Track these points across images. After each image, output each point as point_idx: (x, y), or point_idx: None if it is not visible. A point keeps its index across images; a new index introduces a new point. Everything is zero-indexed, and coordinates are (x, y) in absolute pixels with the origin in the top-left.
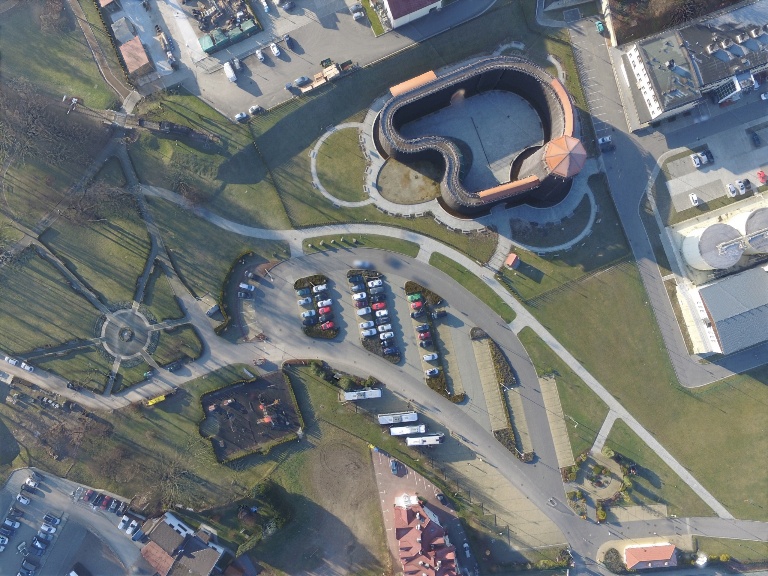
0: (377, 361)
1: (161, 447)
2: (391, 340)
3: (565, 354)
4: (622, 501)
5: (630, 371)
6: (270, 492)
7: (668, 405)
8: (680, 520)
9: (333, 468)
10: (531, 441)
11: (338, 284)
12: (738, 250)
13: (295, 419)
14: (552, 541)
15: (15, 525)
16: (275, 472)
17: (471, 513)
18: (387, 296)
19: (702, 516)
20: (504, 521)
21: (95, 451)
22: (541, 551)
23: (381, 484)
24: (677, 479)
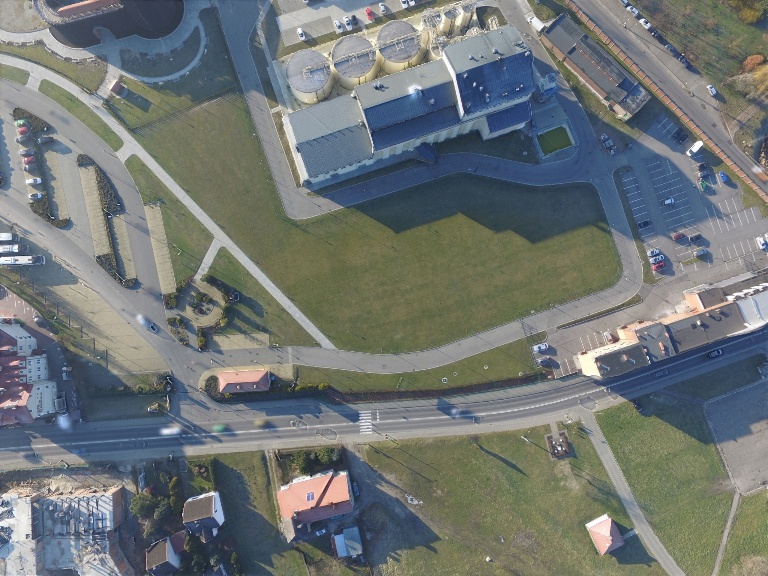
0: None
1: None
2: None
3: (171, 182)
4: (224, 329)
5: (236, 201)
6: None
7: (273, 235)
8: (282, 349)
9: None
10: (135, 268)
11: None
12: (324, 75)
13: None
14: (153, 367)
15: None
16: None
17: (69, 336)
18: None
19: (304, 346)
20: (103, 345)
21: None
22: (140, 376)
23: None
24: (279, 308)
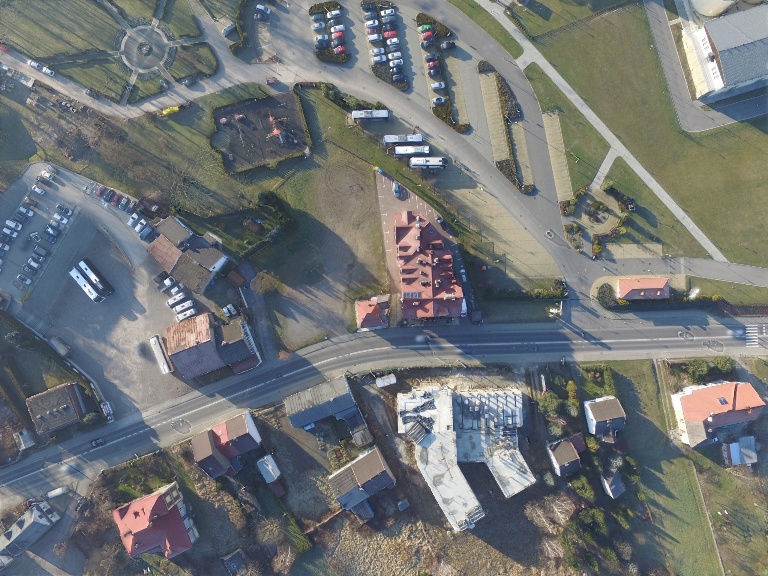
0: (385, 88)
1: (172, 157)
2: (400, 67)
3: (569, 91)
4: (618, 238)
5: (632, 111)
6: (275, 197)
7: (668, 147)
8: (674, 260)
9: (337, 188)
10: (532, 174)
11: (351, 12)
12: None
13: (303, 138)
14: (547, 273)
15: (29, 213)
16: (281, 188)
17: (469, 239)
18: (398, 26)
19: (696, 257)
20: (501, 249)
21: (109, 155)
22: (536, 281)
23: (383, 206)
24: (674, 219)
